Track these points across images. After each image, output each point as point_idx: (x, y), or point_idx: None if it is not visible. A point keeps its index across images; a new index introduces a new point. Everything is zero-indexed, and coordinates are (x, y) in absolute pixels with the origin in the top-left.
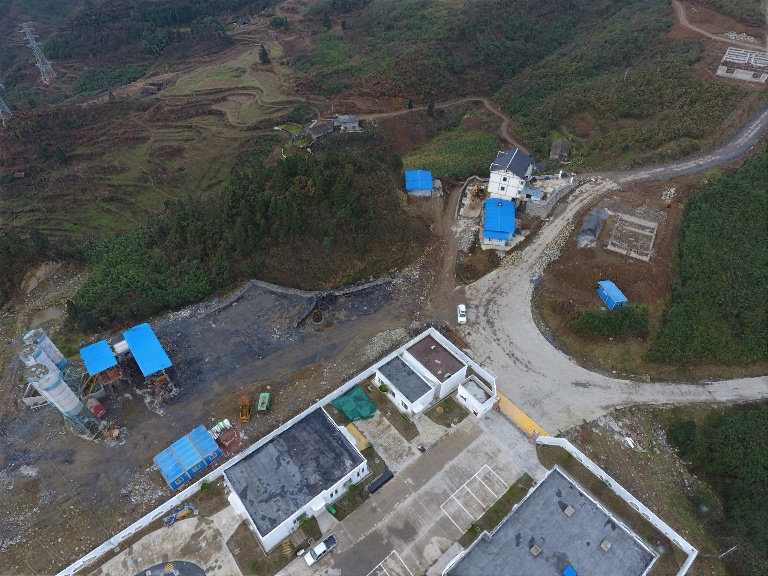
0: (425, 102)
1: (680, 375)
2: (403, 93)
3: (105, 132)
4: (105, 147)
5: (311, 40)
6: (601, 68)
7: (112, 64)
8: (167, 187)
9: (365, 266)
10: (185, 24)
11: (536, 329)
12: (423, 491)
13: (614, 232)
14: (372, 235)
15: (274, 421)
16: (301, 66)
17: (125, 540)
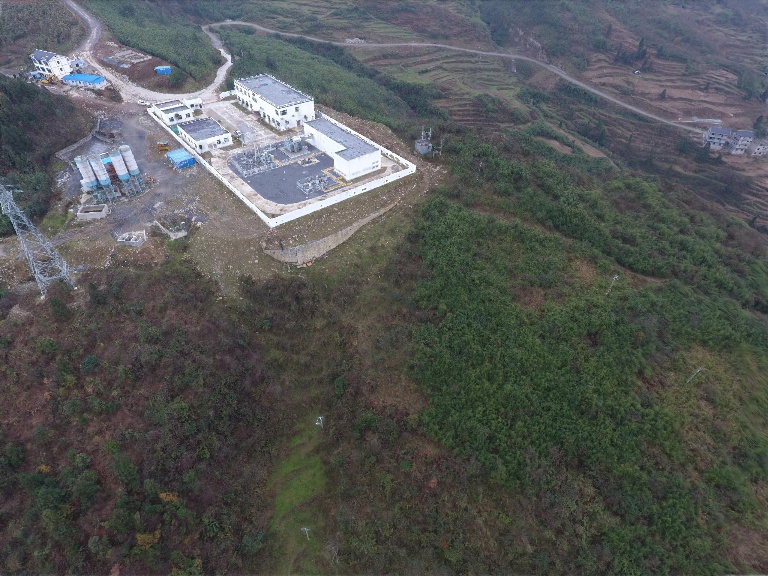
0: None
1: (207, 84)
2: None
3: None
4: None
5: None
6: None
7: None
8: None
9: None
10: None
11: (166, 94)
12: None
13: (126, 59)
14: None
15: (174, 144)
16: None
17: None
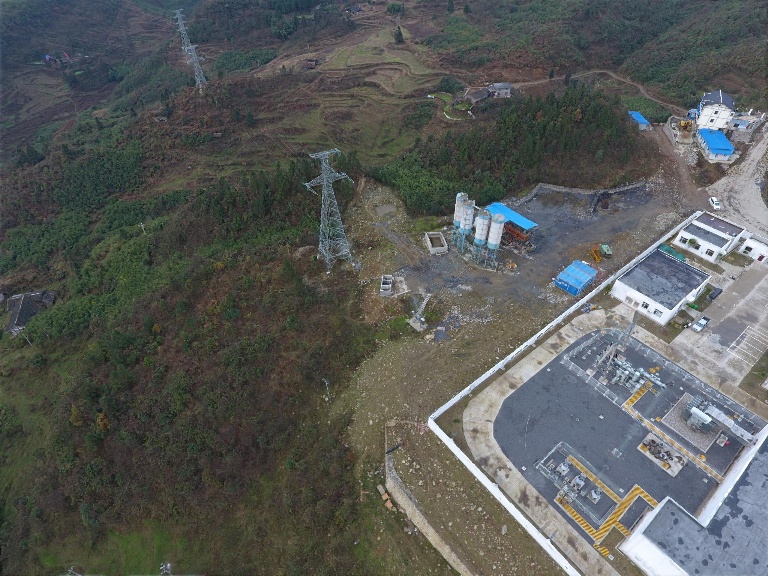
0: (560, 73)
1: None
2: (543, 65)
3: (281, 100)
4: (283, 112)
5: (435, 23)
6: (728, 40)
7: (244, 47)
8: (348, 144)
9: (625, 173)
10: (305, 11)
11: None
12: (748, 299)
13: None
14: (628, 151)
15: (618, 262)
16: (440, 44)
17: (564, 319)
